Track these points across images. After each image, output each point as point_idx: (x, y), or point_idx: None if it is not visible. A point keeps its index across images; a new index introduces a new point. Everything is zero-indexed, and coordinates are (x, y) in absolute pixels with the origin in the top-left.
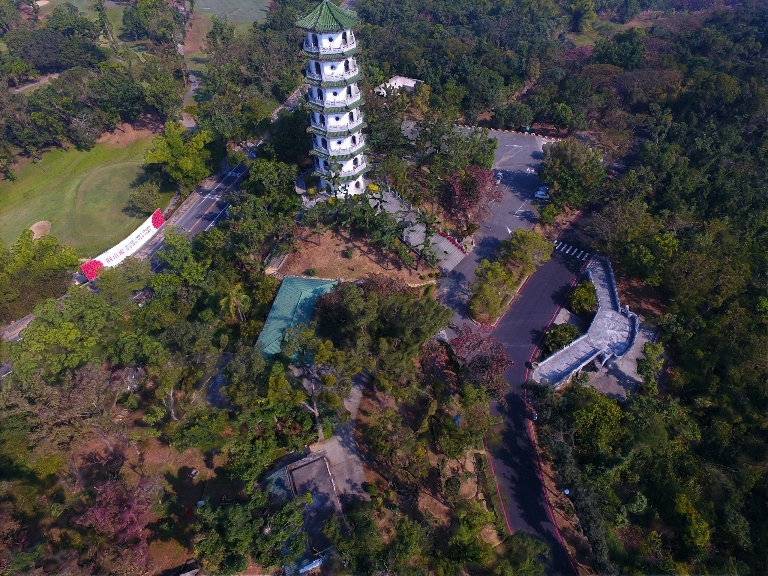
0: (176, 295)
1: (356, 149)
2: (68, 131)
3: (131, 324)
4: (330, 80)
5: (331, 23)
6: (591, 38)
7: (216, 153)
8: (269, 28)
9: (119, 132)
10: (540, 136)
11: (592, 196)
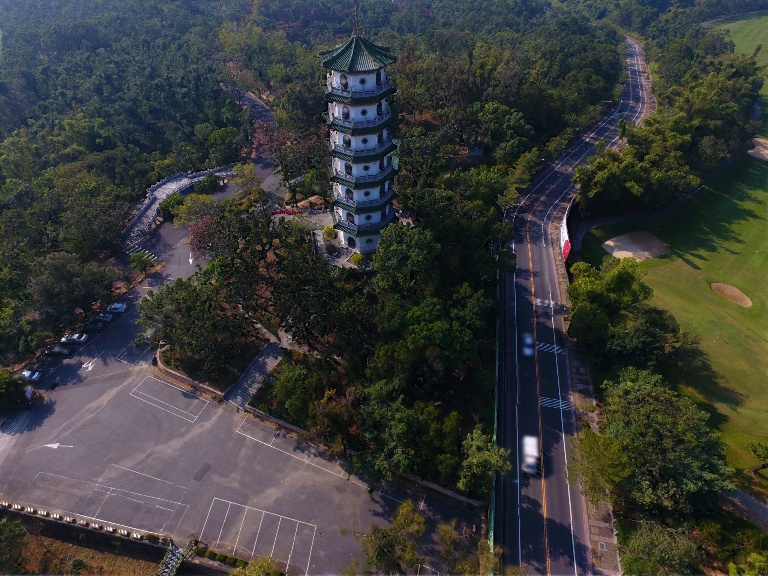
0: None
1: None
2: None
3: None
4: None
5: None
6: None
7: None
8: None
9: None
10: None
11: None
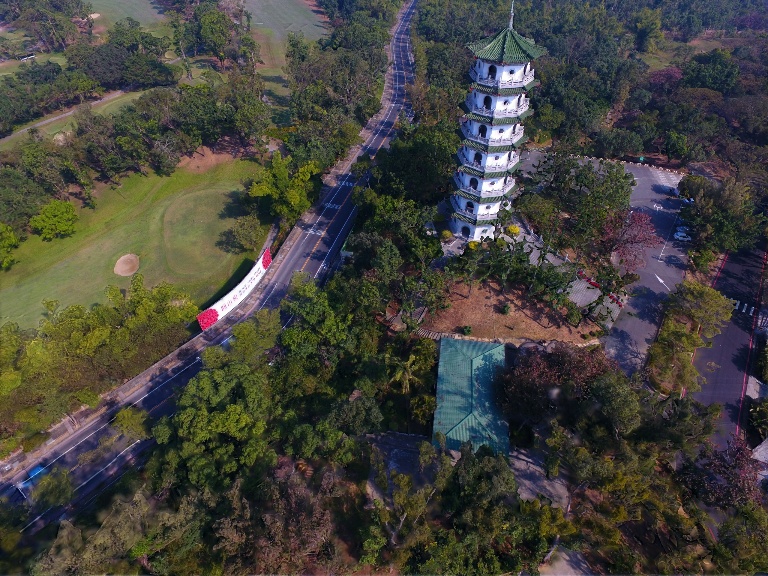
0: (311, 354)
1: (508, 190)
2: (149, 155)
3: (269, 390)
4: (502, 116)
5: (518, 54)
6: (665, 58)
7: (318, 184)
8: (335, 45)
9: (198, 156)
10: (654, 167)
11: (747, 240)
